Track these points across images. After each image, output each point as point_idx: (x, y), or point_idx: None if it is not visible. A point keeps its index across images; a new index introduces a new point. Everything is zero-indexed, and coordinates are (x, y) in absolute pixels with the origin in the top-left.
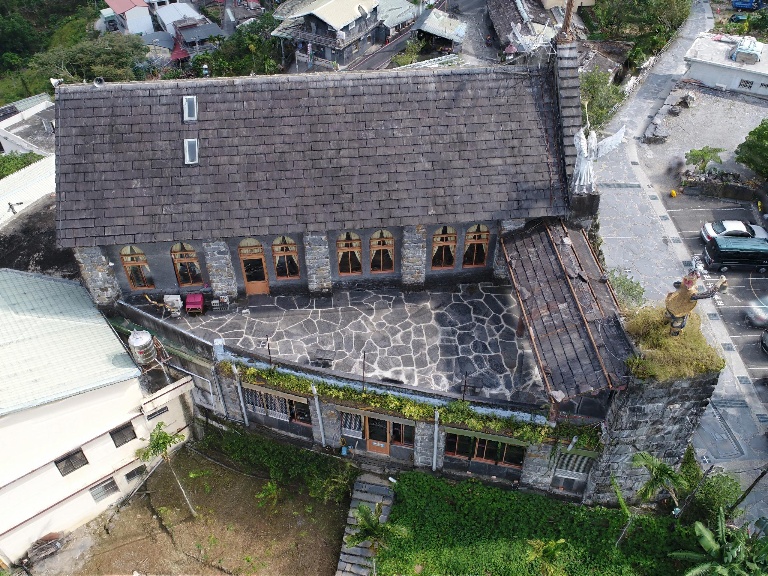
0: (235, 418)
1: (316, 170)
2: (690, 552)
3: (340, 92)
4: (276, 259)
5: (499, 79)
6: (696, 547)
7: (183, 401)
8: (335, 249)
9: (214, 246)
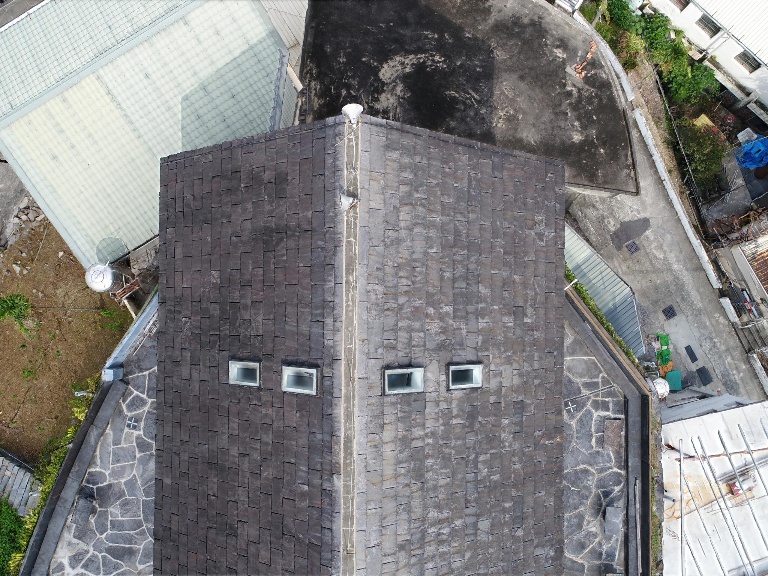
0: None
1: None
2: None
3: None
4: None
5: None
6: None
7: None
8: None
9: None
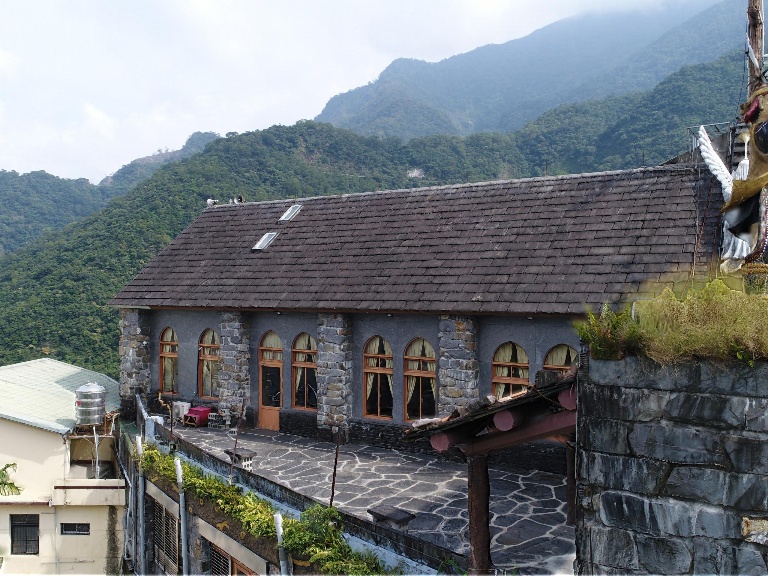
0: (140, 573)
1: (366, 257)
2: None
3: (437, 197)
4: (298, 376)
5: (646, 178)
6: None
7: (112, 531)
8: (360, 365)
9: (230, 328)
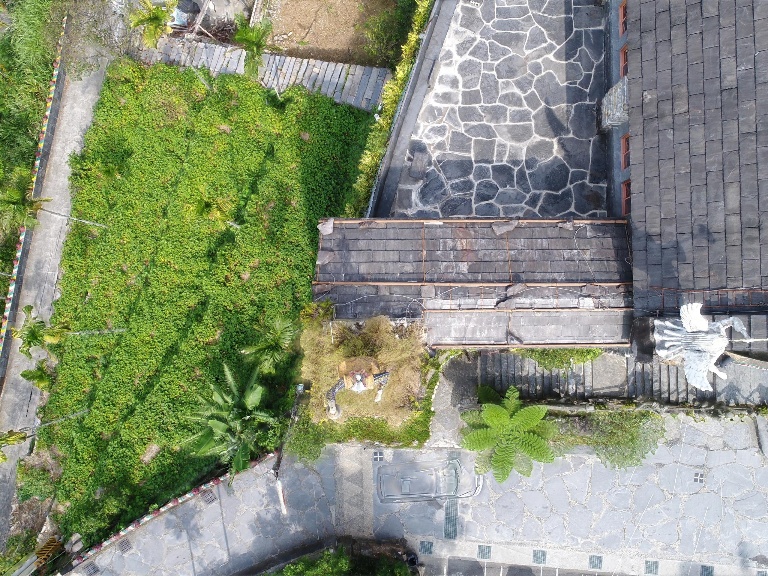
0: None
1: None
2: (255, 382)
3: None
4: None
5: None
6: (280, 402)
7: None
8: None
9: None
